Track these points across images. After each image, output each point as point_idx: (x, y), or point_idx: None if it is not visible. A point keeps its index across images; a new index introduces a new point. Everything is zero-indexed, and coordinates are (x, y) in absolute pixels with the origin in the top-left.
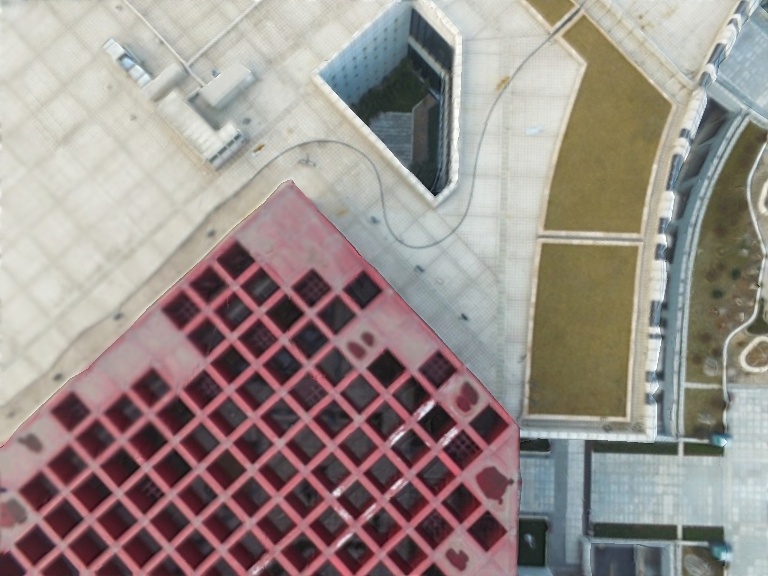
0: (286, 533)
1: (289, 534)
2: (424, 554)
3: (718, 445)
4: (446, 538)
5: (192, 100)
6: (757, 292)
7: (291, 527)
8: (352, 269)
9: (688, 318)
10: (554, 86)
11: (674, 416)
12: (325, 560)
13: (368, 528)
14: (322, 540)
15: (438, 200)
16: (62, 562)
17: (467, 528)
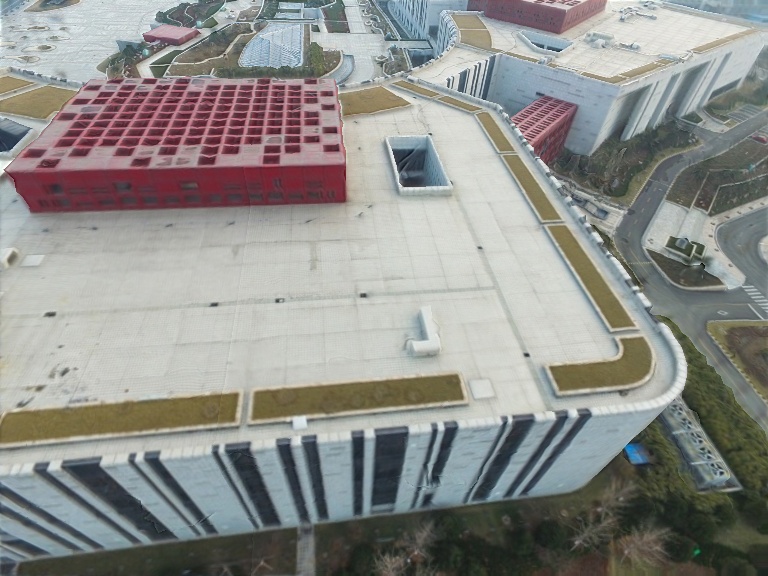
0: None
1: None
2: None
3: None
4: None
5: (606, 42)
6: None
7: None
8: (542, 3)
9: None
10: (499, 46)
11: None
12: None
13: None
14: None
15: (522, 30)
16: None
17: None
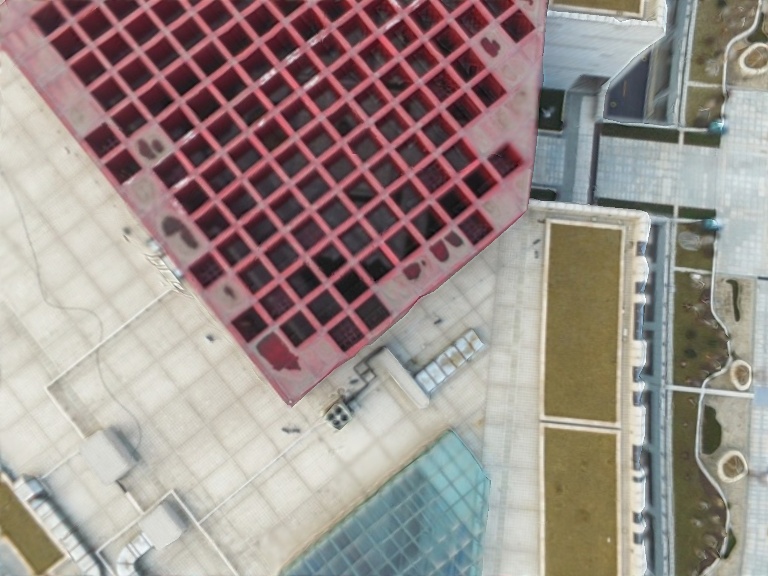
0: (342, 14)
1: (345, 15)
2: (462, 40)
3: (715, 127)
4: (482, 30)
5: None
6: (758, 5)
7: (347, 9)
8: None
9: (694, 25)
10: None
11: (677, 110)
12: (375, 40)
13: (414, 17)
14: (373, 23)
15: None
16: (144, 20)
17: (500, 22)
